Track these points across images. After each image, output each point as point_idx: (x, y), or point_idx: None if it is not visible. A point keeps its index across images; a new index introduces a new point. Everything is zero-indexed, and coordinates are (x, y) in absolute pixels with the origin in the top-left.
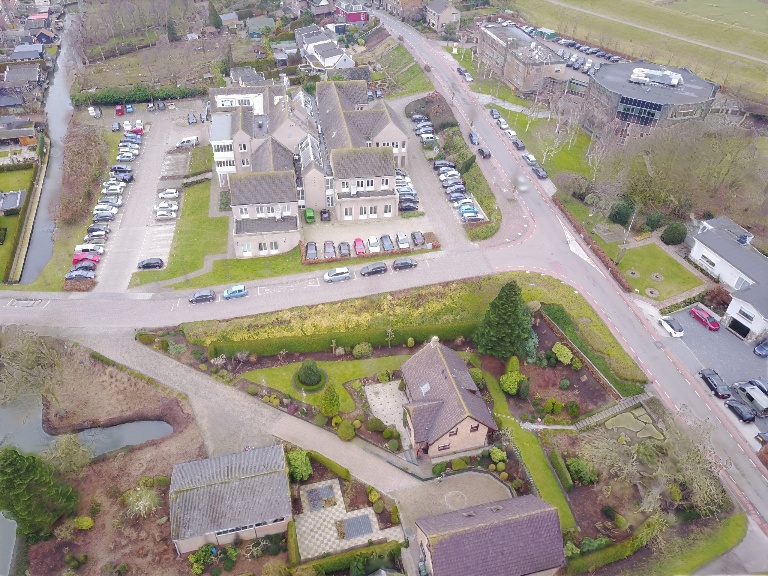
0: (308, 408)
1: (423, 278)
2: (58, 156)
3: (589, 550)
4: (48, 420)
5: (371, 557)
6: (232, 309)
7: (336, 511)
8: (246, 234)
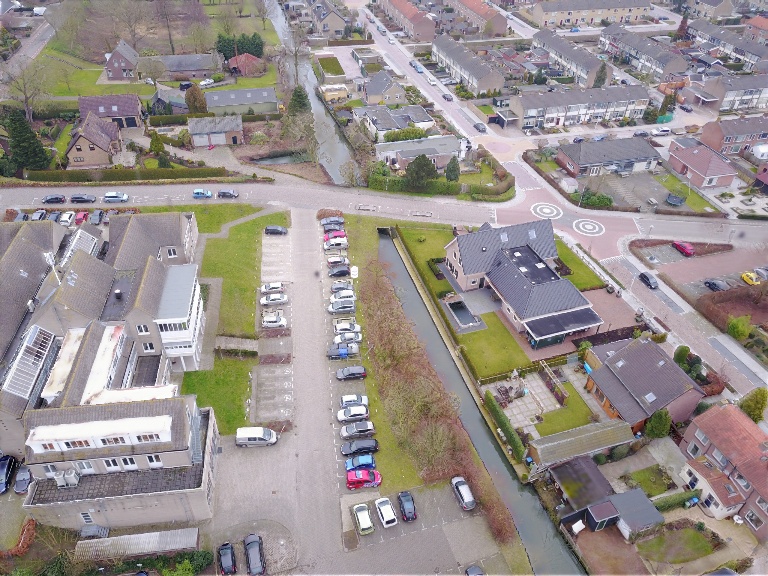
0: (172, 159)
1: (48, 192)
2: (480, 438)
3: (72, 112)
4: (320, 164)
5: (162, 104)
6: (207, 188)
7: (172, 133)
8: (182, 213)
